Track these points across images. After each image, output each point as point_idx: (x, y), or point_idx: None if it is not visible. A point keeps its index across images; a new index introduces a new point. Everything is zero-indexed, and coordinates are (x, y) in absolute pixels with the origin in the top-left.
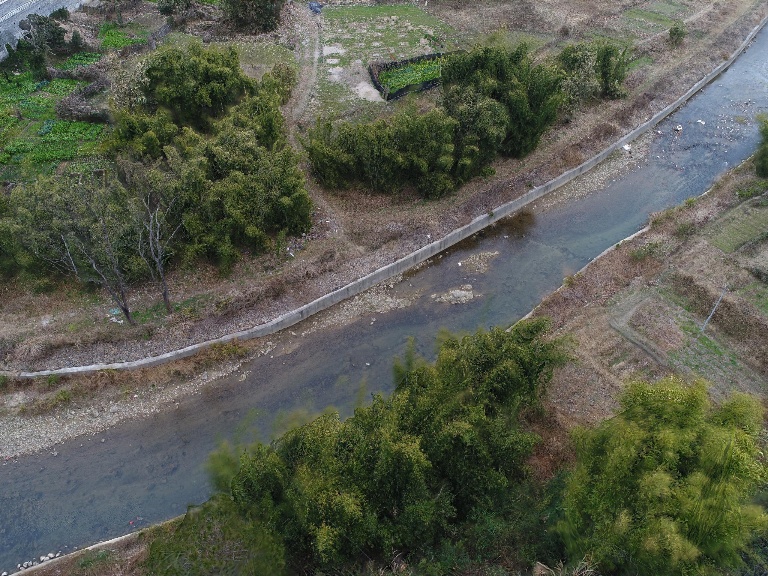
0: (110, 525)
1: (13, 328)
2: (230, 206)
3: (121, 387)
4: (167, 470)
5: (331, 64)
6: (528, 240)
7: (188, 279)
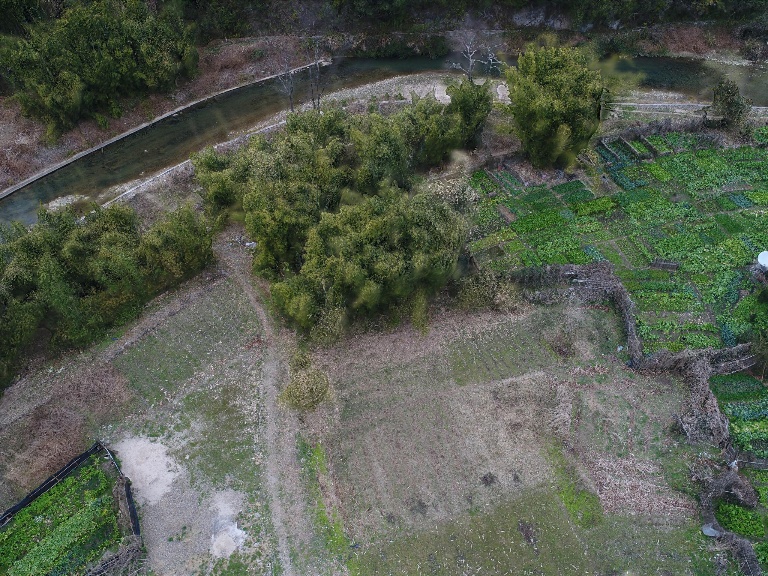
0: (274, 84)
1: None
2: None
3: None
4: (257, 98)
5: (247, 575)
6: None
7: None
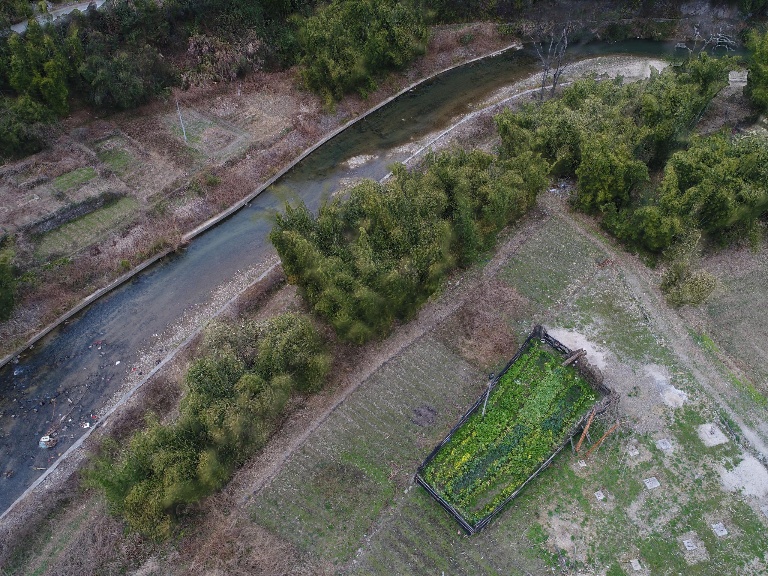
0: None
1: None
2: None
3: None
4: (475, 77)
5: (702, 418)
6: None
7: None
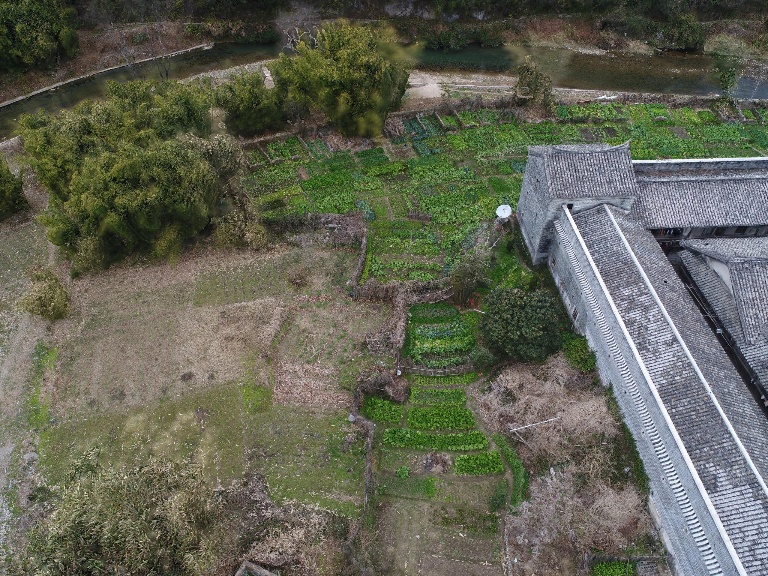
0: None
1: None
2: None
3: None
4: (133, 77)
5: None
6: None
7: None
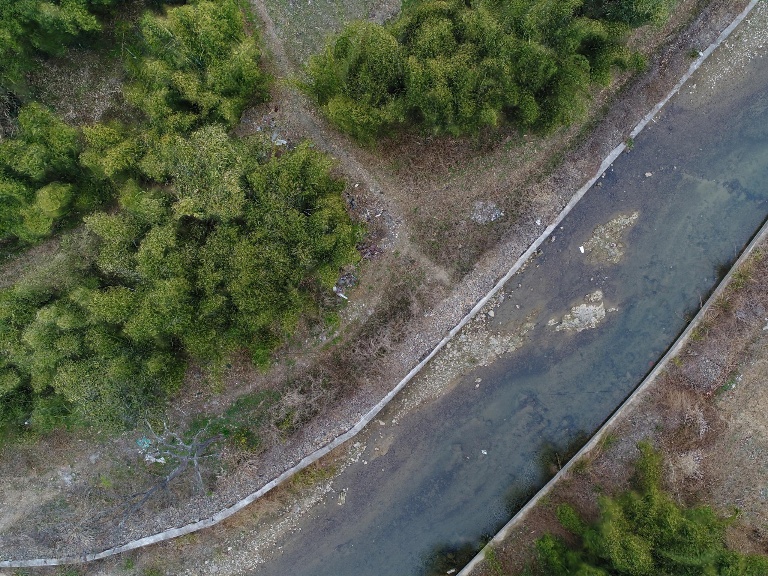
0: None
1: (34, 497)
2: (245, 305)
3: (208, 542)
4: None
5: None
6: (681, 174)
7: (214, 370)
